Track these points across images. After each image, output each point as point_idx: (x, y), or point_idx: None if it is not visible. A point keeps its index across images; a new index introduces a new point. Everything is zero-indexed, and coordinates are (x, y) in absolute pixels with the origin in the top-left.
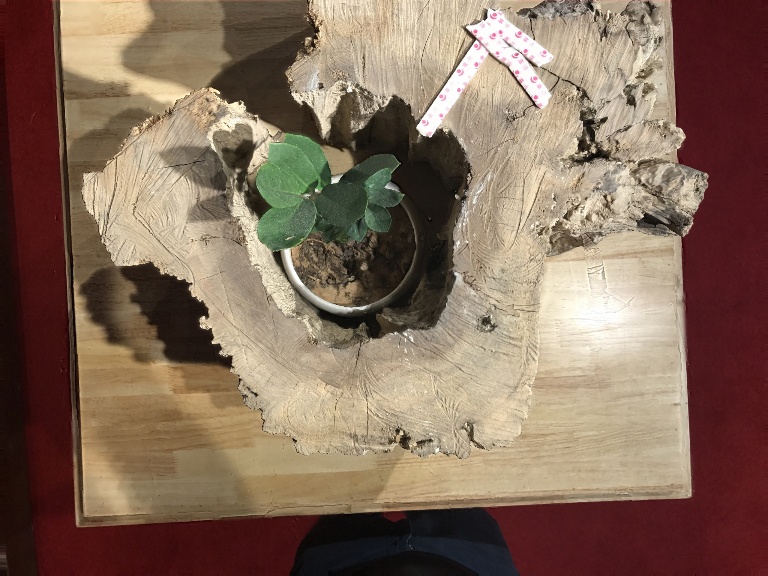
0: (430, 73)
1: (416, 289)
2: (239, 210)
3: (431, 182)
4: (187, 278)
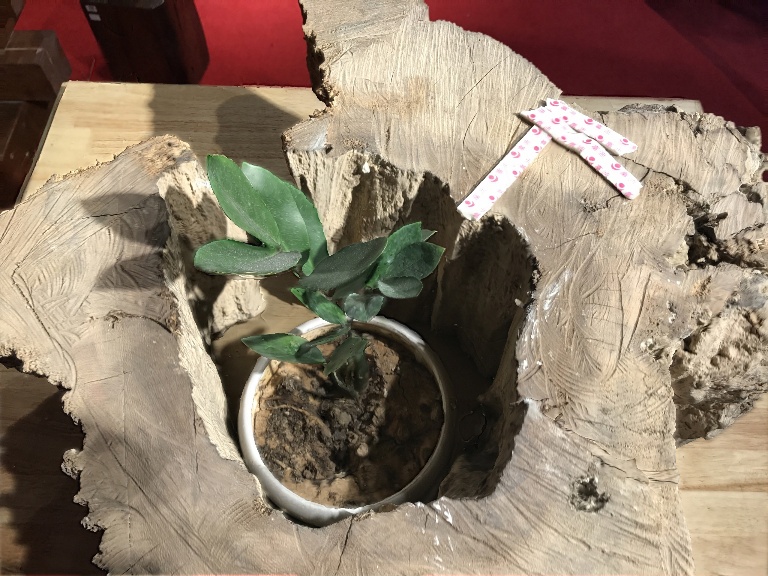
0: (475, 154)
1: None
2: (182, 301)
3: (460, 364)
4: (65, 379)
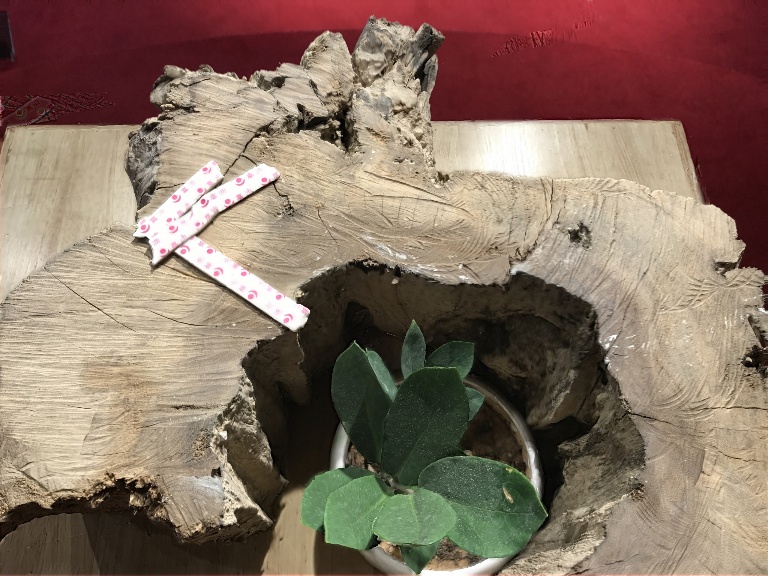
0: (214, 313)
1: (502, 373)
2: None
3: None
4: None
